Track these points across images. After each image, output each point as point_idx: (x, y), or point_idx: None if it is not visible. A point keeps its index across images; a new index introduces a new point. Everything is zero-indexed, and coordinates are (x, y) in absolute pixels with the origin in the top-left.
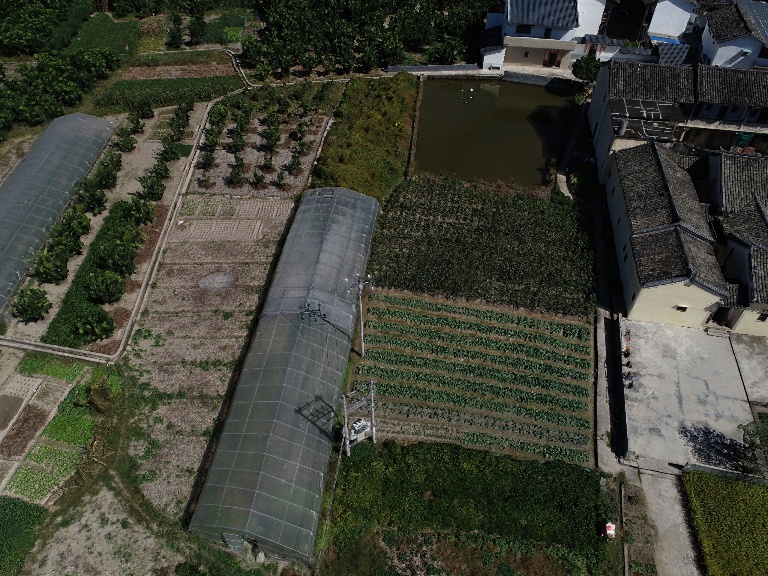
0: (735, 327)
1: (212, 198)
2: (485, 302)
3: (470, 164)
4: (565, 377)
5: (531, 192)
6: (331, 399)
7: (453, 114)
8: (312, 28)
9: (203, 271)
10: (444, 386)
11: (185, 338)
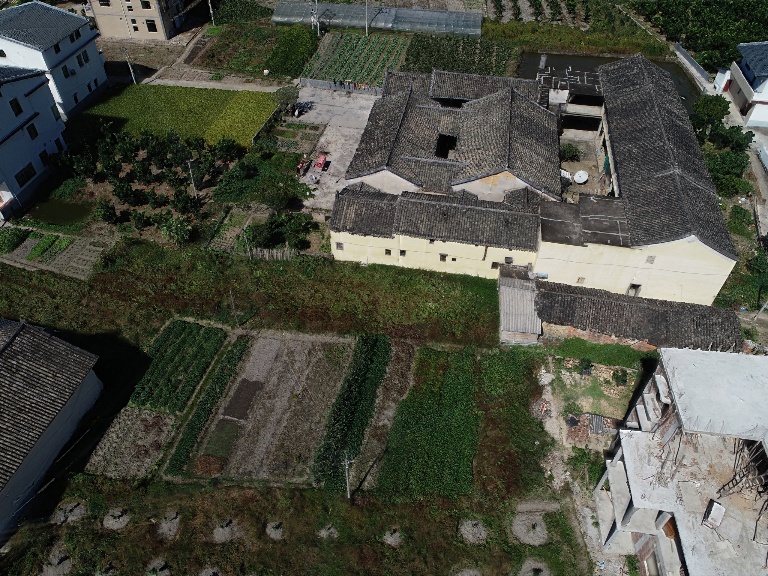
0: None
1: (483, 4)
2: None
3: None
4: None
5: None
6: (335, 19)
7: None
8: (701, 3)
9: (423, 5)
10: None
11: (380, 5)
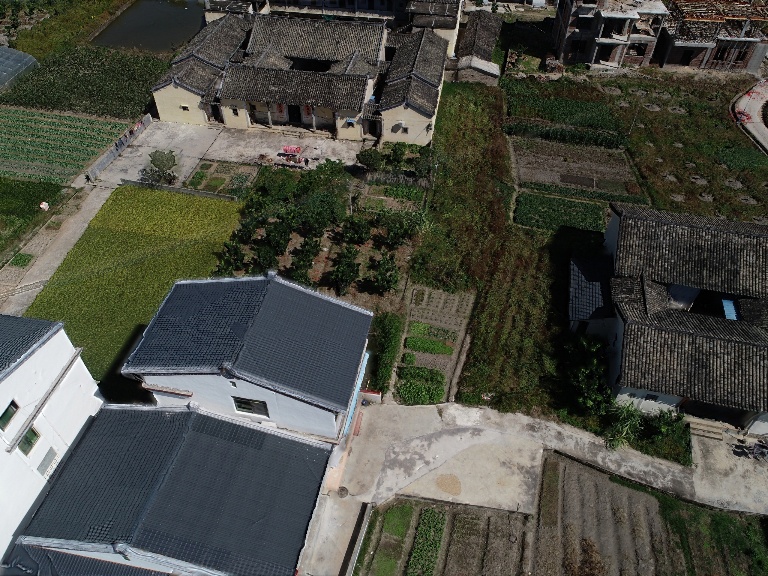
0: (225, 122)
1: None
2: (72, 113)
3: (133, 42)
4: (90, 147)
5: (155, 55)
6: None
7: (150, 14)
8: None
9: None
10: (5, 150)
11: None
